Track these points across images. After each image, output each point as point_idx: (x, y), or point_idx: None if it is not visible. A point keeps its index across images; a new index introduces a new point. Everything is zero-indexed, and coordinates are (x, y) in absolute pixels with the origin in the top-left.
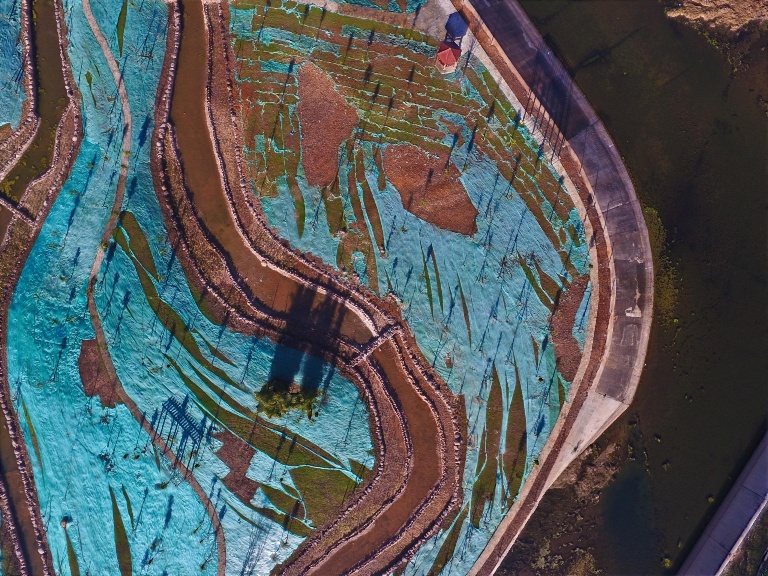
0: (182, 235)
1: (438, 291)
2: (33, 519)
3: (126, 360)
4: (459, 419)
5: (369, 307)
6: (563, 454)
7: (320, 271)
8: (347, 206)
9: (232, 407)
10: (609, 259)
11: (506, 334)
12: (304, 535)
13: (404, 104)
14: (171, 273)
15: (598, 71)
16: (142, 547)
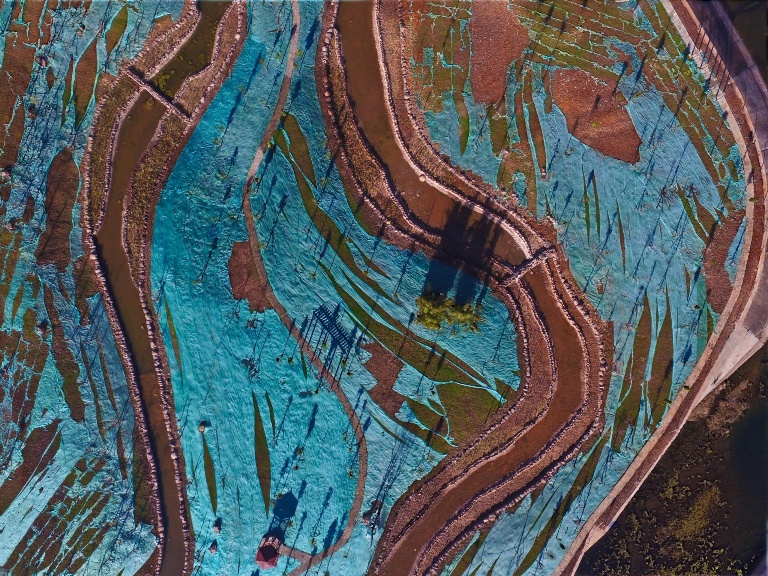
0: (342, 143)
1: (596, 217)
2: (167, 423)
3: (278, 265)
4: (606, 345)
5: (524, 229)
6: (707, 384)
7: (479, 189)
8: (512, 126)
9: (384, 319)
10: (764, 196)
11: (660, 263)
12: (445, 452)
13: (576, 29)
14: (329, 180)
15: (756, 17)
16: (282, 455)
